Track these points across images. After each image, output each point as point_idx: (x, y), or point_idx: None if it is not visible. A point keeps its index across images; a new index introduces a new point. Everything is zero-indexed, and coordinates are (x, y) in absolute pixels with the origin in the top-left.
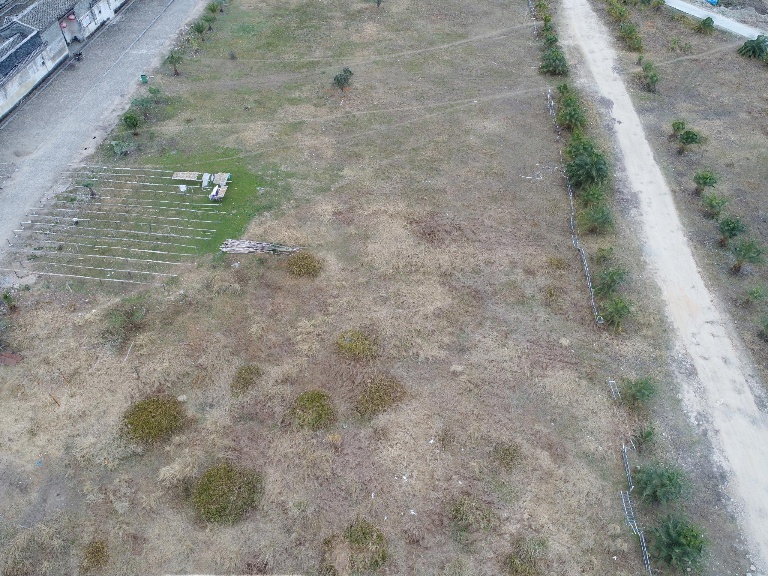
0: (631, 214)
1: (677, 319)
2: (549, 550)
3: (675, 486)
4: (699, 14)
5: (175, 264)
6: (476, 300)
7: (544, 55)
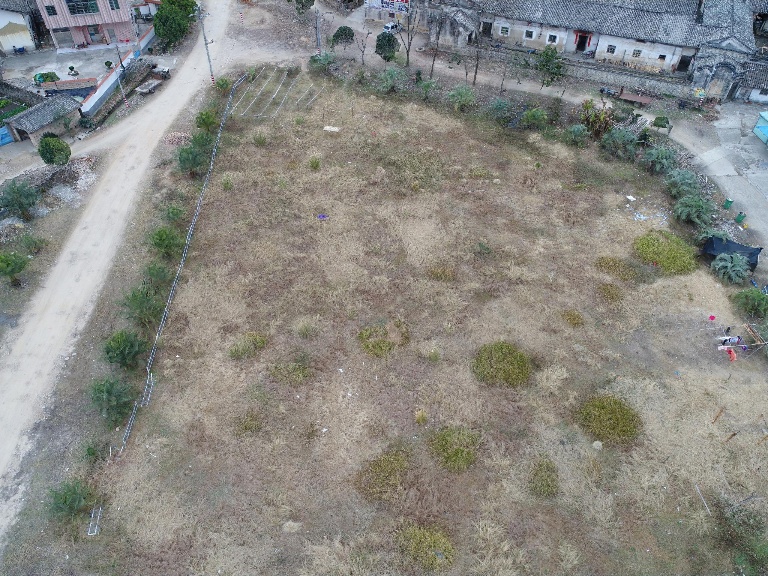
0: None
1: None
2: None
3: None
4: None
5: None
6: None
7: None
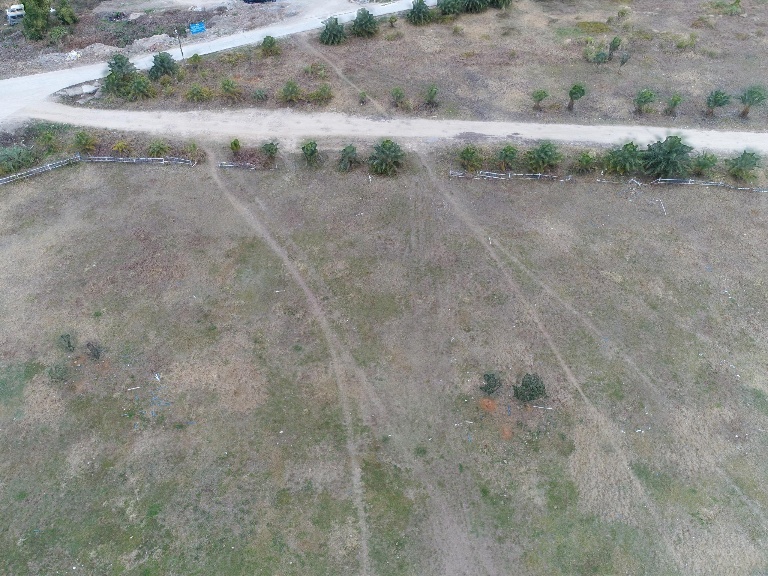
0: (694, 152)
1: None
2: None
3: None
4: (223, 46)
5: None
6: None
7: (343, 165)
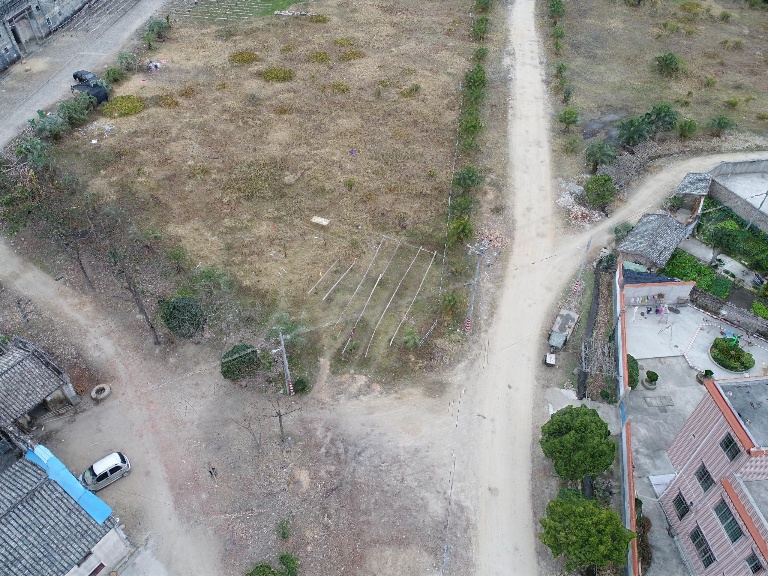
0: (508, 7)
1: (514, 39)
2: (421, 92)
3: (481, 71)
4: None
5: (250, 18)
6: (409, 32)
7: None
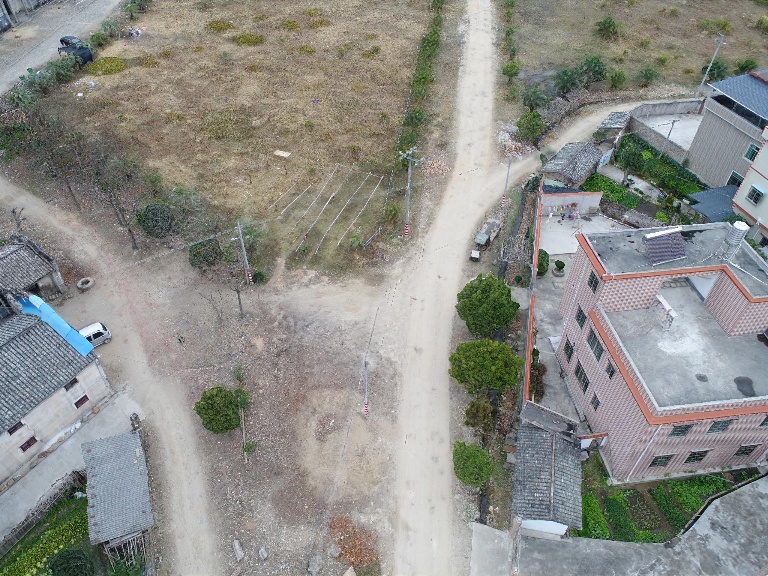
0: None
1: (470, 10)
2: (381, 53)
3: (436, 34)
4: None
5: None
6: (374, 4)
7: None
